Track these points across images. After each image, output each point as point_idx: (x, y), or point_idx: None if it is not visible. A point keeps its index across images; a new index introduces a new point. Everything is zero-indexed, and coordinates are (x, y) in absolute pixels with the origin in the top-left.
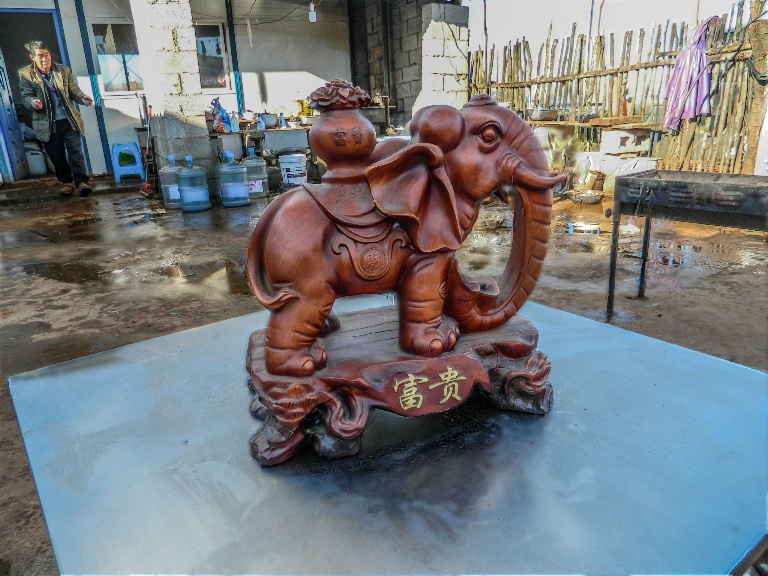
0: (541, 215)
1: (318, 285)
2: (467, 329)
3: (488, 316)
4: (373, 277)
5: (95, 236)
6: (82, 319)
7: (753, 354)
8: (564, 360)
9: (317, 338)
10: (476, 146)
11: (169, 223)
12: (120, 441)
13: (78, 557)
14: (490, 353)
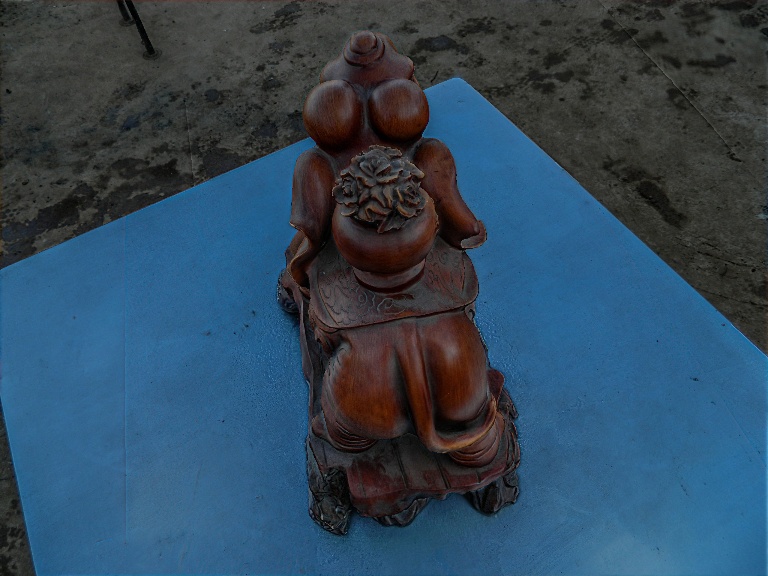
0: None
1: None
2: None
3: None
4: None
5: None
6: None
7: (130, 69)
8: None
9: None
10: None
11: None
12: None
13: None
14: None
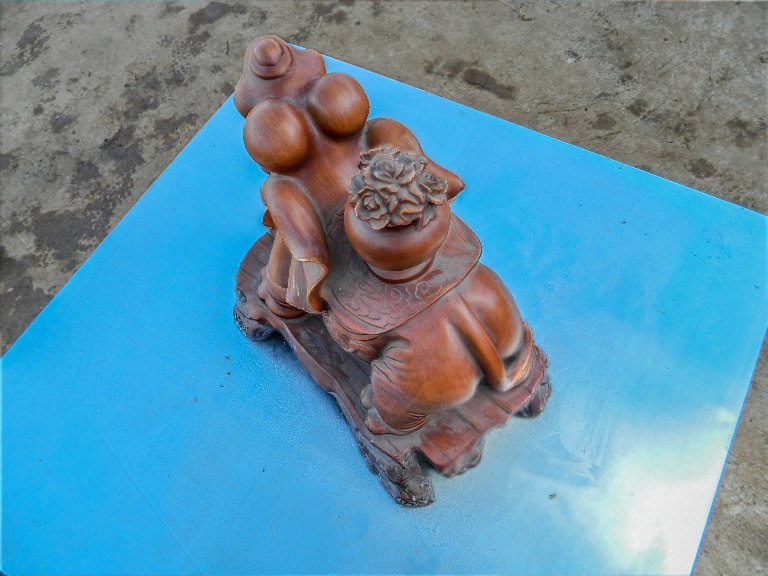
0: None
1: None
2: None
3: None
4: None
5: None
6: None
7: None
8: (257, 216)
9: None
10: None
11: None
12: (588, 575)
13: (708, 467)
14: None
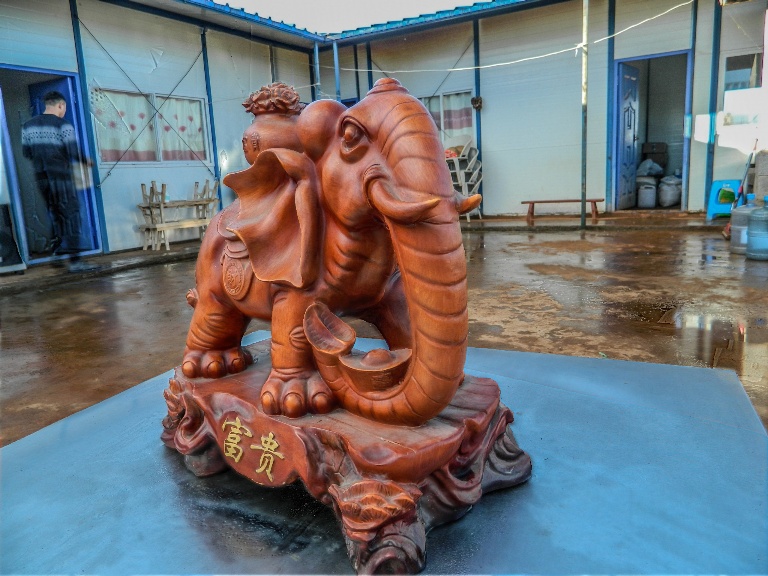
0: (415, 266)
1: (205, 291)
2: (347, 406)
3: (367, 399)
4: (233, 296)
5: (628, 268)
6: (528, 334)
7: None
8: (576, 561)
9: (234, 350)
10: (339, 153)
11: (713, 268)
12: None
13: None
14: (336, 447)
